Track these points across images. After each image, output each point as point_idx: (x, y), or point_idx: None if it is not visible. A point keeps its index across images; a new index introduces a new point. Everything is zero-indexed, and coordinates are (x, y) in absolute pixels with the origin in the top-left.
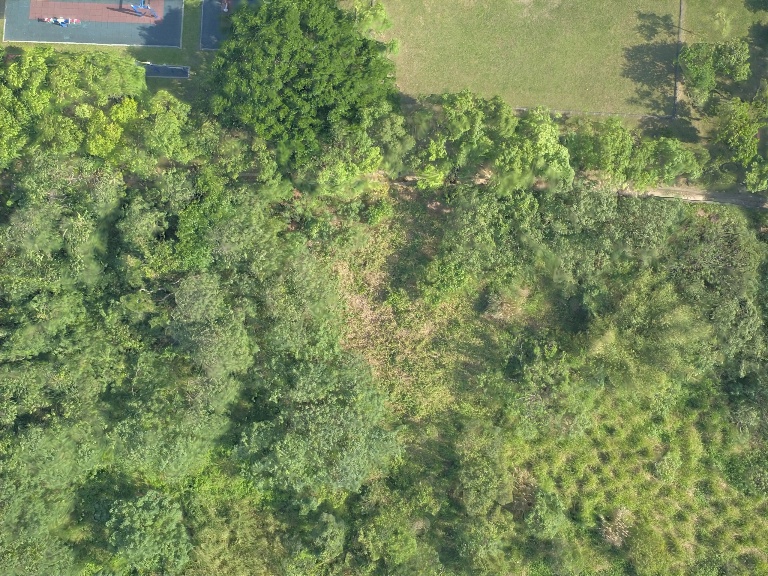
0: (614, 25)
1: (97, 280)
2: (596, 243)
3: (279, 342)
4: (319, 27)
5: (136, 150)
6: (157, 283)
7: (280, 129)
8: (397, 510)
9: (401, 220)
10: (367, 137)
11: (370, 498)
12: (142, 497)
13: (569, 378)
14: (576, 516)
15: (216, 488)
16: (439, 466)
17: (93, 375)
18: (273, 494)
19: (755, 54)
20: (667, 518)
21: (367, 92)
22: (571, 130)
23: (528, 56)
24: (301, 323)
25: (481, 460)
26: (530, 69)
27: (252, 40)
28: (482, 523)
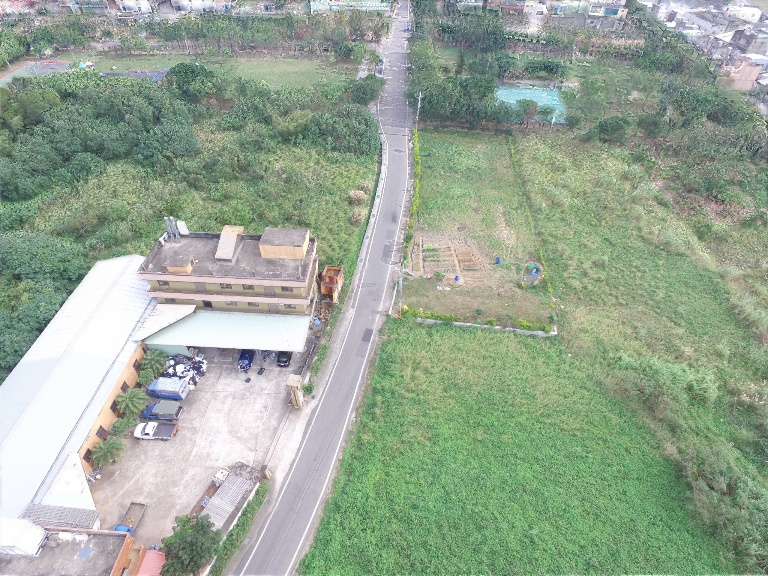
0: None
1: None
2: None
3: None
4: None
5: None
6: None
7: None
8: None
9: None
10: None
11: None
12: None
13: None
14: None
15: None
16: None
17: None
18: None
19: (341, 94)
20: None
21: None
22: None
23: None
24: None
25: None
26: None
27: None
28: None
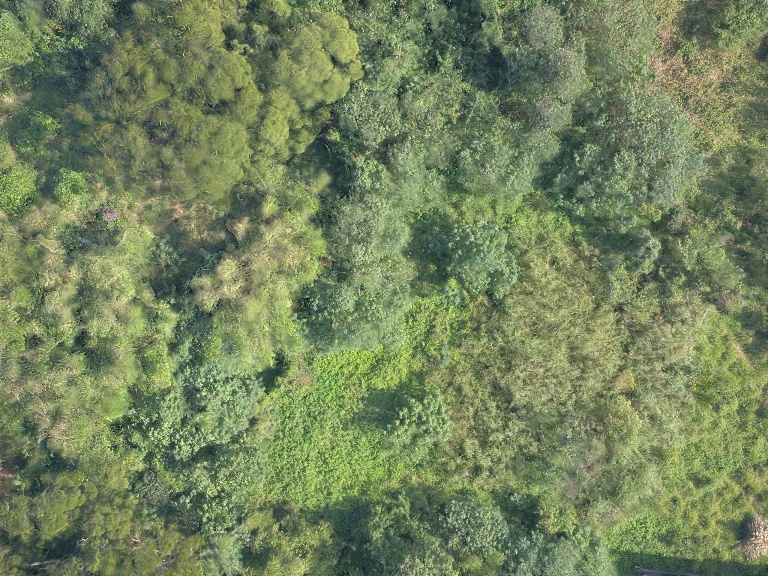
0: None
1: (425, 36)
2: None
3: (604, 74)
4: None
5: None
6: (501, 20)
7: None
8: (703, 227)
9: None
10: None
11: (679, 218)
12: (480, 220)
13: None
14: None
15: (530, 224)
16: (732, 194)
17: None
18: (581, 227)
19: None
20: None
21: None
22: None
23: None
24: None
25: None
26: None
27: None
28: None
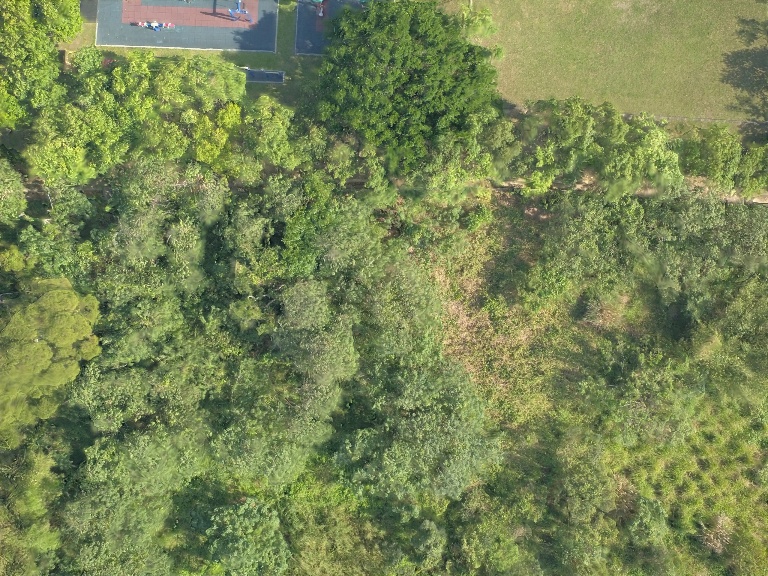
0: (713, 30)
1: None
2: (703, 250)
3: (383, 349)
4: (429, 33)
5: (243, 156)
6: (262, 290)
7: (391, 135)
8: (498, 517)
9: (499, 226)
10: (476, 143)
11: (470, 505)
12: (243, 505)
13: (673, 385)
14: (675, 523)
15: (311, 495)
16: (537, 473)
17: (194, 382)
18: (369, 501)
19: None
20: (767, 525)
21: (473, 98)
22: (669, 136)
23: (627, 61)
24: (407, 330)
25: (584, 467)
26: (629, 74)
27: (365, 46)
28: (587, 531)
